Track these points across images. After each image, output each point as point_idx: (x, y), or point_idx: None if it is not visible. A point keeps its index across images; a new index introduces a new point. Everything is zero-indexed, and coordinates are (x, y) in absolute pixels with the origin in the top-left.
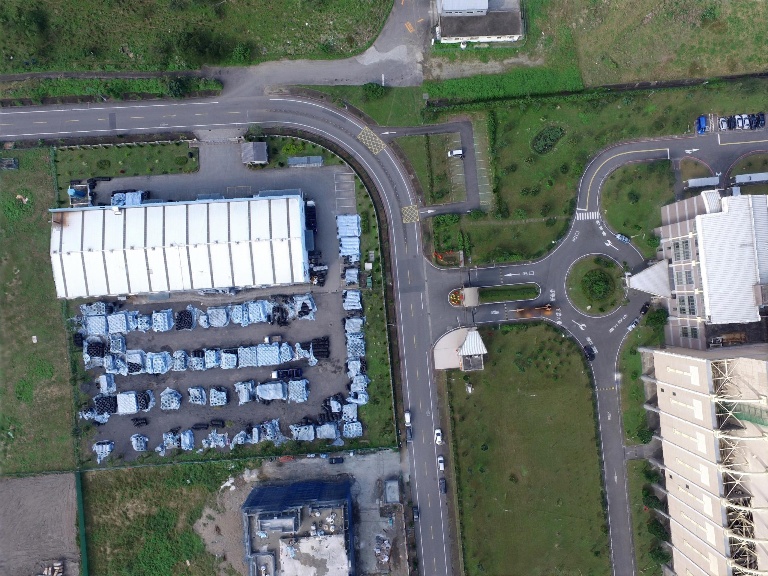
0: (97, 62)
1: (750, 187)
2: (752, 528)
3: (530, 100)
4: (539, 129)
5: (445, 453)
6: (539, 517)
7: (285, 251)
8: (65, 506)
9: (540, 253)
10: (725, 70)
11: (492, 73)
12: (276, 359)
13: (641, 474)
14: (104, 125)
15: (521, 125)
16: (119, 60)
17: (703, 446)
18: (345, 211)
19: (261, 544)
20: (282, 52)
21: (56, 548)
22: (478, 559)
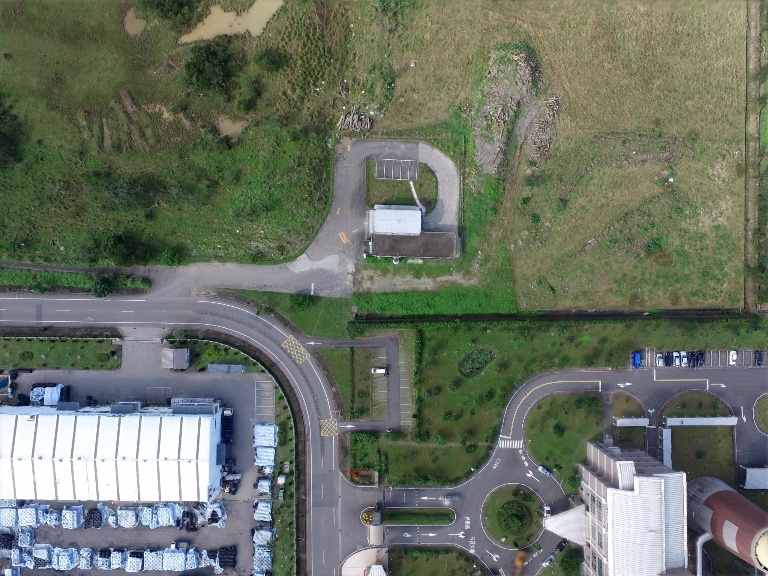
0: (28, 253)
1: (683, 427)
2: None
3: (459, 324)
4: (467, 352)
5: None
6: None
7: (192, 472)
8: None
9: (457, 480)
10: (667, 303)
11: (424, 290)
12: (181, 566)
13: None
14: (30, 315)
15: (449, 346)
16: (50, 252)
17: None
18: (263, 420)
19: None
20: (212, 254)
21: None
22: None
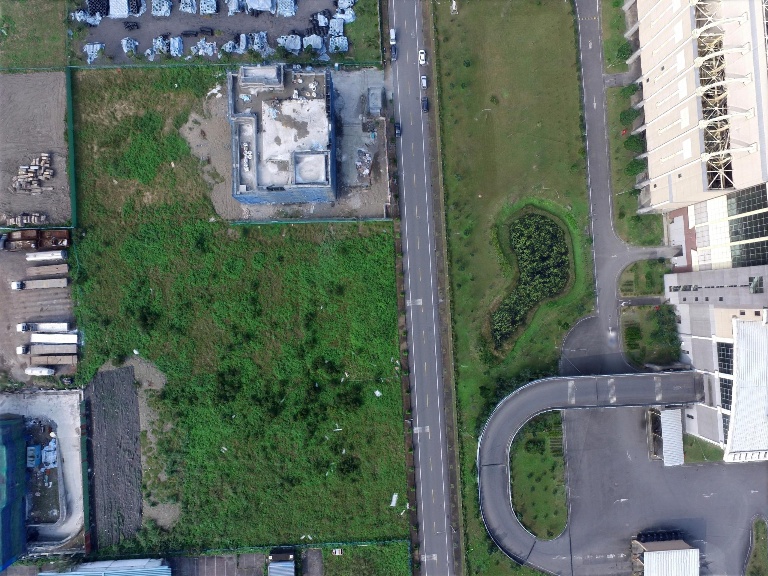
0: None
1: None
2: (723, 72)
3: None
4: None
5: (428, 74)
6: (518, 139)
7: None
8: (55, 103)
9: None
10: None
11: None
12: None
13: (620, 101)
14: None
15: None
16: None
17: (678, 2)
18: None
19: (244, 107)
20: None
21: (44, 142)
22: None
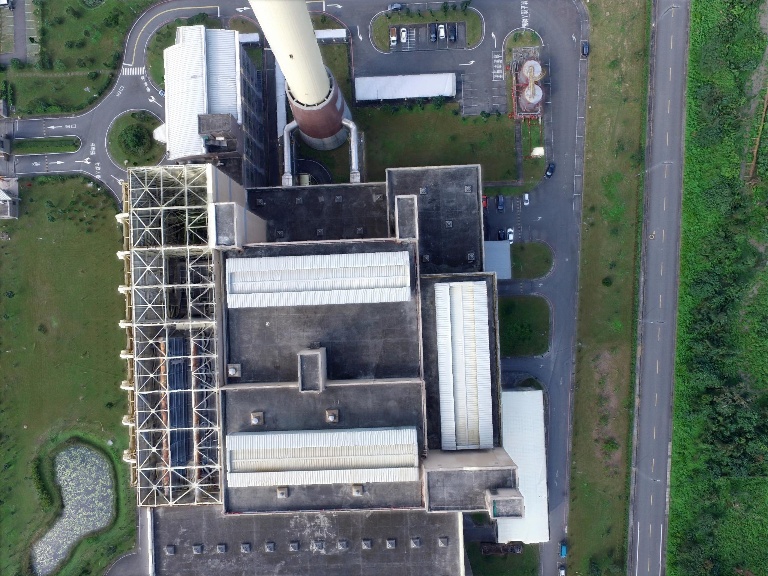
0: None
1: None
2: None
3: None
4: None
5: None
6: (66, 369)
7: None
8: None
9: (80, 105)
10: None
11: None
12: None
13: None
14: None
15: None
16: None
17: None
18: None
19: None
20: None
21: None
22: (4, 406)
